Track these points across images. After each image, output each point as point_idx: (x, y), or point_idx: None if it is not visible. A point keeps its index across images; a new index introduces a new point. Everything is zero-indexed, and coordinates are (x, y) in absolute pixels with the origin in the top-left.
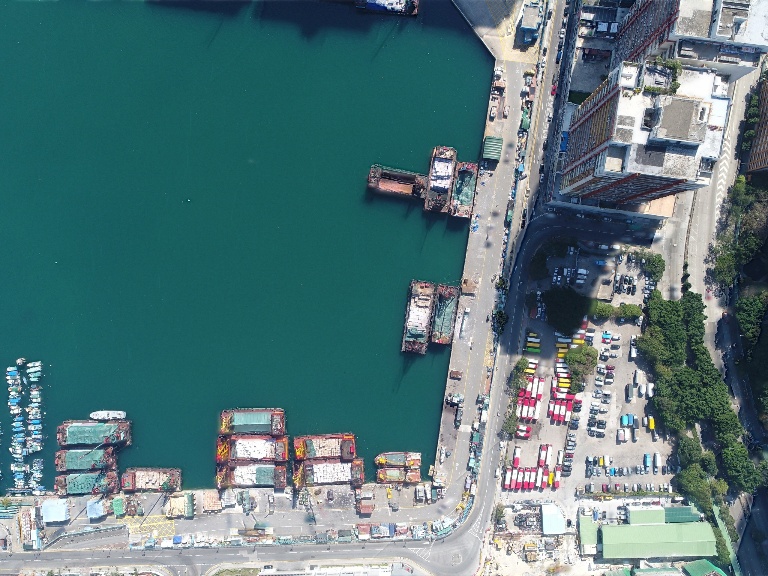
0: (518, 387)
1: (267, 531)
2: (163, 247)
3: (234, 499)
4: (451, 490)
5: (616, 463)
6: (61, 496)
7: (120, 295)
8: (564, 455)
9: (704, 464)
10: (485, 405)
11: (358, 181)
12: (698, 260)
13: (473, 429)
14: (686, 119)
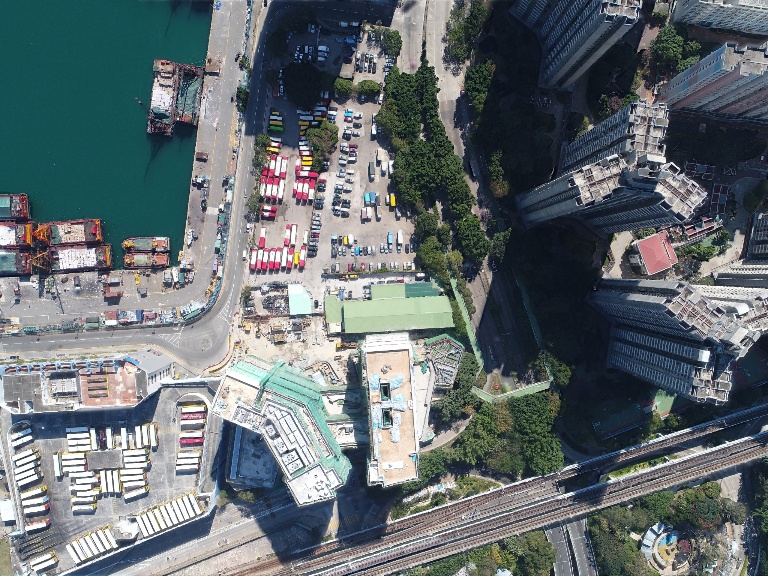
0: (262, 166)
1: (13, 321)
2: None
3: None
4: (200, 274)
5: (361, 242)
6: None
7: None
8: (310, 235)
9: (440, 236)
10: (230, 185)
11: None
12: (436, 39)
13: (219, 211)
14: None
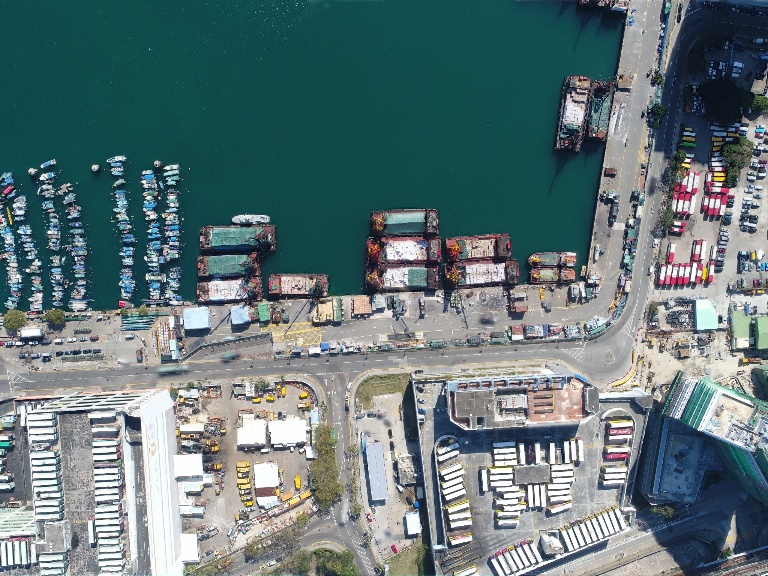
0: (673, 182)
1: (417, 335)
2: (310, 44)
3: (385, 302)
4: (604, 289)
5: (767, 258)
6: (201, 305)
7: (263, 95)
8: (717, 251)
9: None
10: (641, 200)
11: None
12: None
13: (627, 226)
14: None
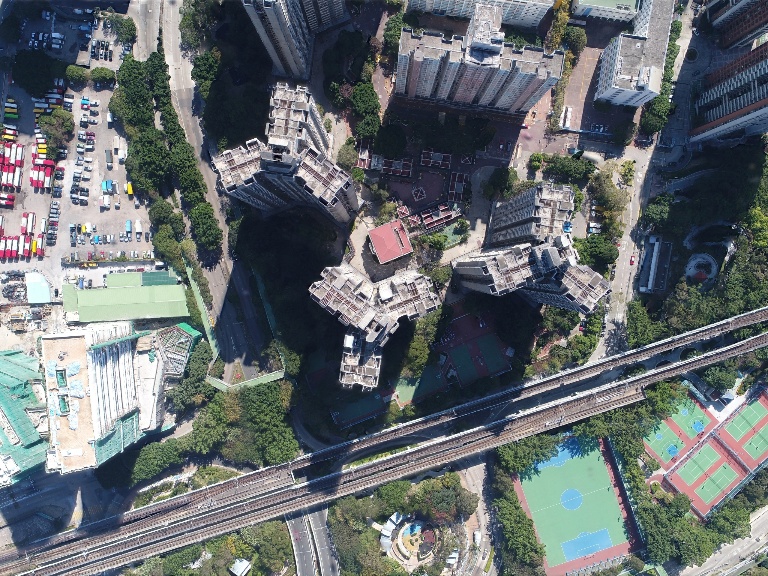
0: None
1: None
2: None
3: None
4: None
5: (100, 231)
6: None
7: None
8: (48, 223)
9: (172, 224)
10: None
11: None
12: (173, 26)
13: None
14: None
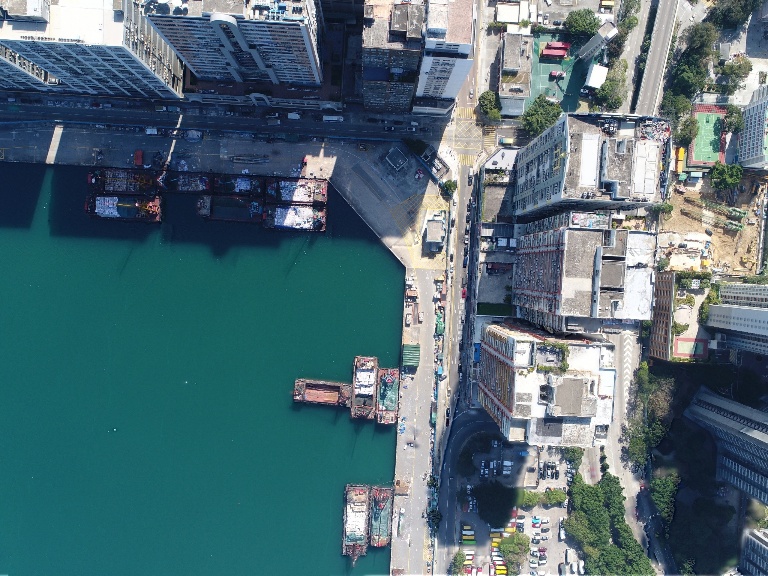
0: None
1: None
2: (93, 477)
3: None
4: None
5: None
6: None
7: (53, 529)
8: None
9: None
10: None
11: (284, 394)
12: (613, 440)
13: None
14: (578, 396)
